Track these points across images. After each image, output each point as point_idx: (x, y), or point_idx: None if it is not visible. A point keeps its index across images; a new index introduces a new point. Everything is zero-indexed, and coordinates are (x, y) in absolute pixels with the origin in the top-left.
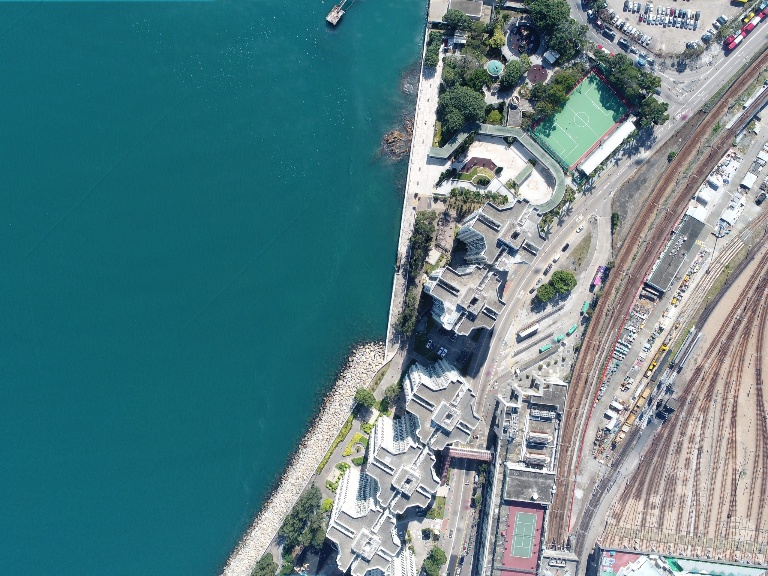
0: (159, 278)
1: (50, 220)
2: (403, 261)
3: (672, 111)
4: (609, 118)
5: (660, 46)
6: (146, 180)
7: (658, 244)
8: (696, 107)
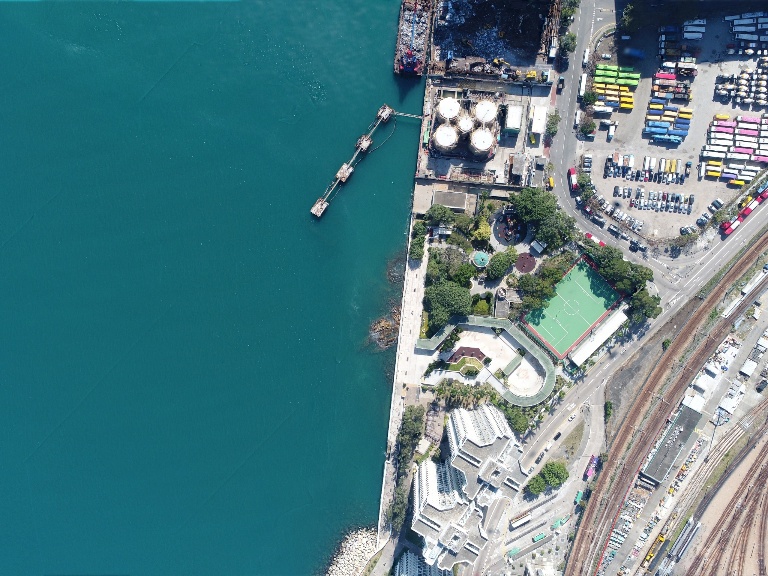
0: (152, 482)
1: (47, 427)
2: (393, 450)
3: (666, 297)
4: (600, 305)
5: (652, 231)
6: (137, 387)
7: (653, 434)
8: (691, 293)
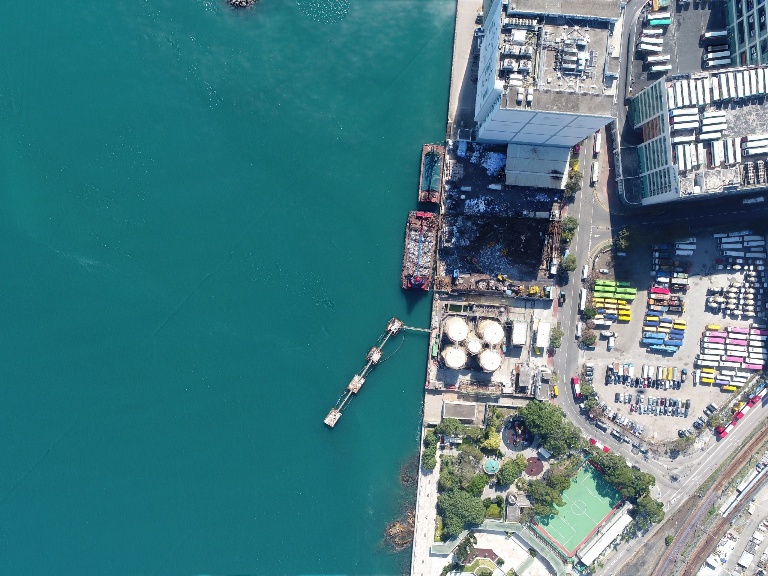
0: None
1: None
2: None
3: (667, 496)
4: (606, 505)
5: (652, 434)
6: None
7: None
8: (691, 491)
